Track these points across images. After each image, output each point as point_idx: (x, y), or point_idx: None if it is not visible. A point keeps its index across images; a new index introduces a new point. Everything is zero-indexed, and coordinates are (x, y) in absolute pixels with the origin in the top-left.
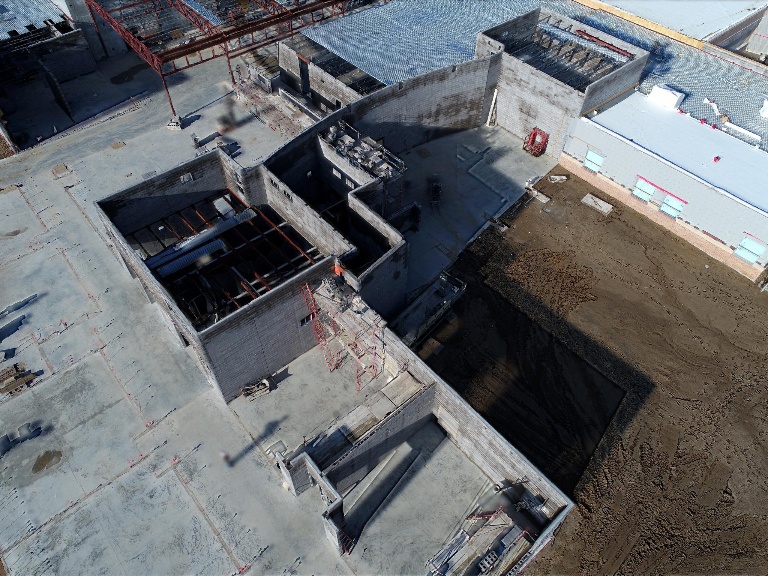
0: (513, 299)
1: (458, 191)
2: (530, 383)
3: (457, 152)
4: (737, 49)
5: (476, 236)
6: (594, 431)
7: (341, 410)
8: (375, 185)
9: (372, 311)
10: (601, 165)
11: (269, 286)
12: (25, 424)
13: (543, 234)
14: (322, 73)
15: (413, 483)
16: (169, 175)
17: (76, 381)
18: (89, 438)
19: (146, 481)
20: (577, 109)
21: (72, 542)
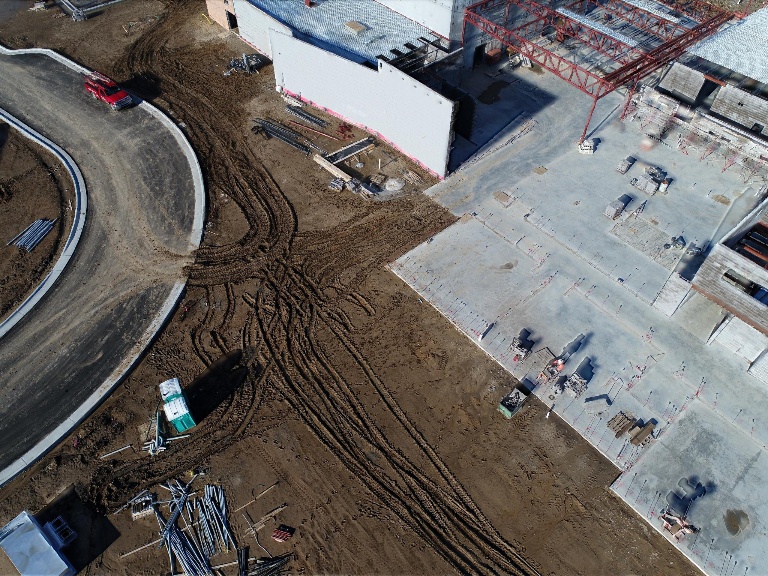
0: None
1: None
2: None
3: None
4: None
5: None
6: None
7: None
8: None
9: None
10: None
11: None
12: (682, 479)
13: None
14: (746, 96)
15: None
16: None
17: (697, 431)
18: (760, 495)
19: None
20: None
21: None
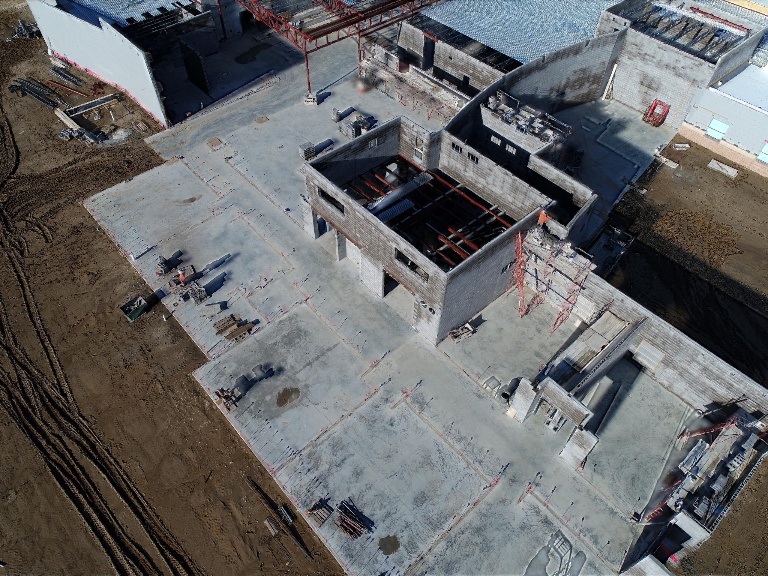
0: (667, 253)
1: (592, 158)
2: (702, 325)
3: (581, 123)
4: None
5: (620, 198)
6: None
7: (540, 350)
8: (550, 147)
9: (588, 254)
10: (725, 132)
11: (466, 239)
12: (257, 366)
13: (679, 196)
14: (452, 50)
15: (622, 410)
16: (362, 140)
17: (292, 328)
18: (319, 377)
19: (383, 412)
20: (706, 80)
21: (333, 463)
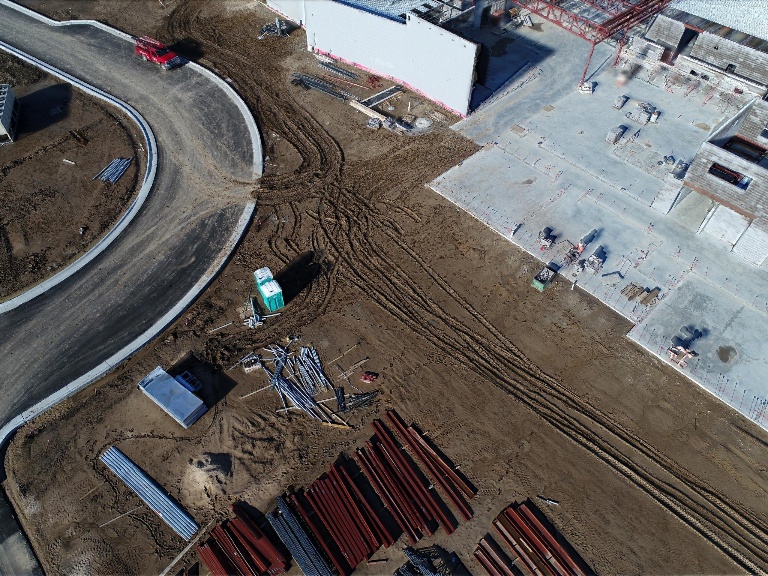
0: None
1: None
2: None
3: None
4: None
5: None
6: None
7: None
8: None
9: None
10: None
11: None
12: (683, 327)
13: None
14: (720, 40)
15: None
16: None
17: (693, 294)
18: (745, 336)
19: None
20: None
21: None
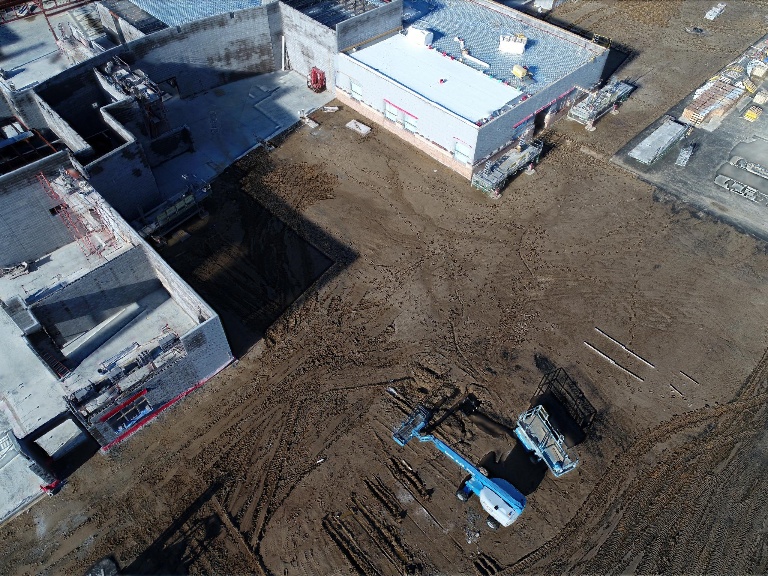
0: (262, 200)
1: (240, 121)
2: (256, 259)
3: (249, 91)
4: (522, 4)
5: (244, 154)
6: (297, 290)
7: None
8: (128, 103)
9: (88, 189)
10: (362, 94)
11: None
12: None
13: (305, 152)
14: (128, 26)
15: (132, 330)
16: None
17: None
18: None
19: None
20: (335, 46)
21: None
